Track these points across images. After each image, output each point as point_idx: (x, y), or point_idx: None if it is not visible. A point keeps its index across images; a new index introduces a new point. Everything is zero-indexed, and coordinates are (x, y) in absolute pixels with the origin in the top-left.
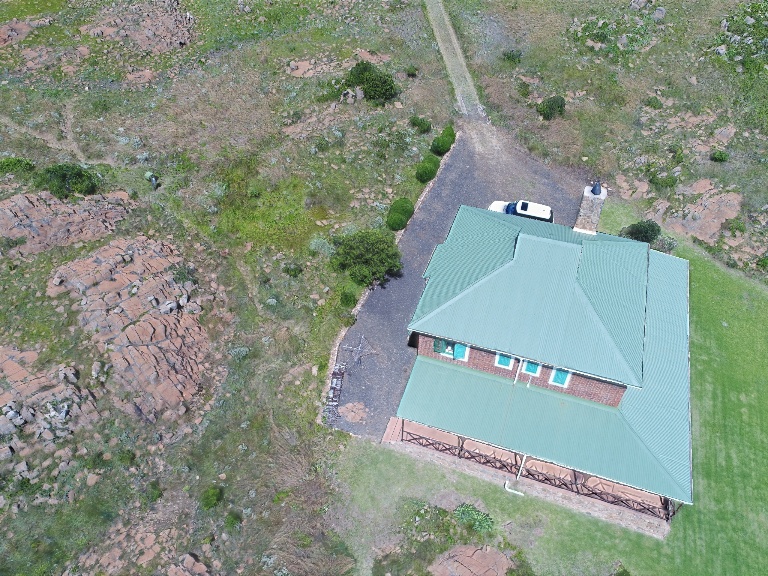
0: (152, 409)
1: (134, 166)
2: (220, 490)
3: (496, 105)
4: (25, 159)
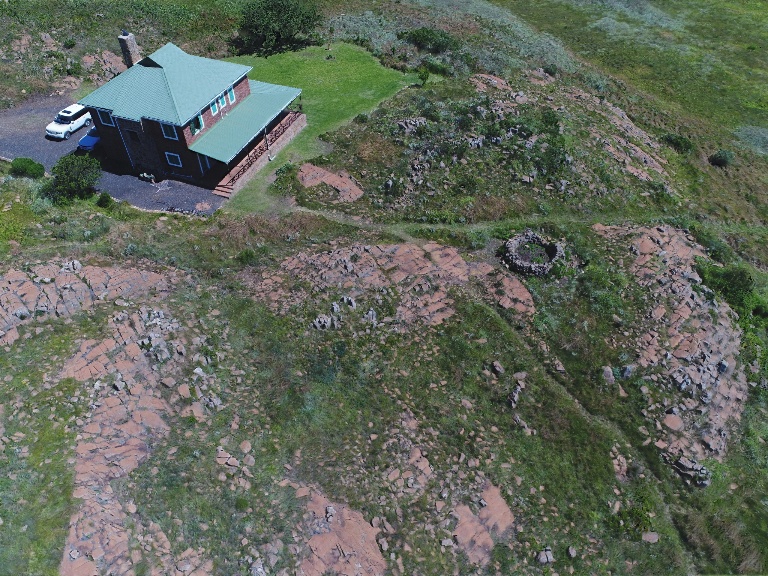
0: (167, 285)
1: None
2: None
3: None
4: None
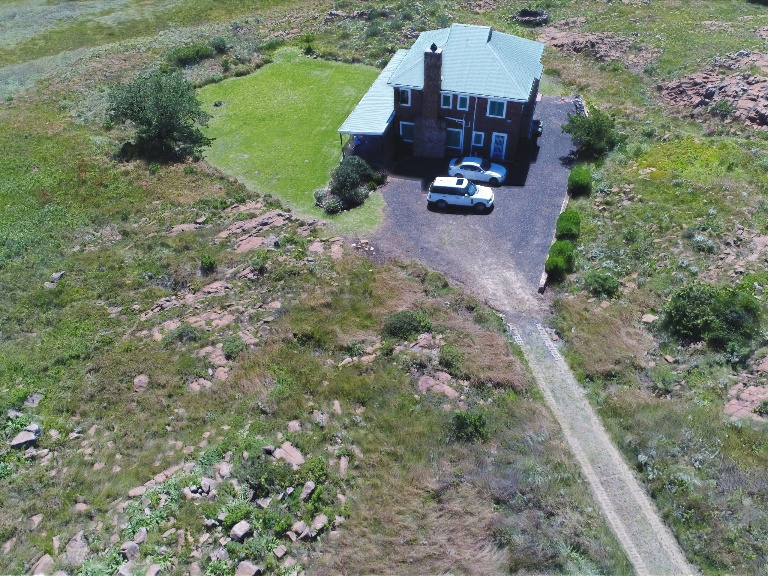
0: None
1: None
2: (615, 69)
3: None
4: None
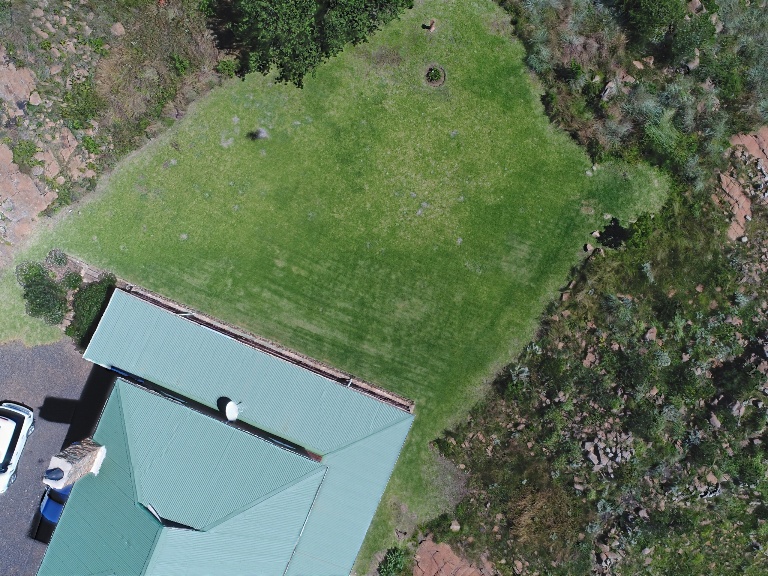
0: None
1: None
2: None
3: None
4: None
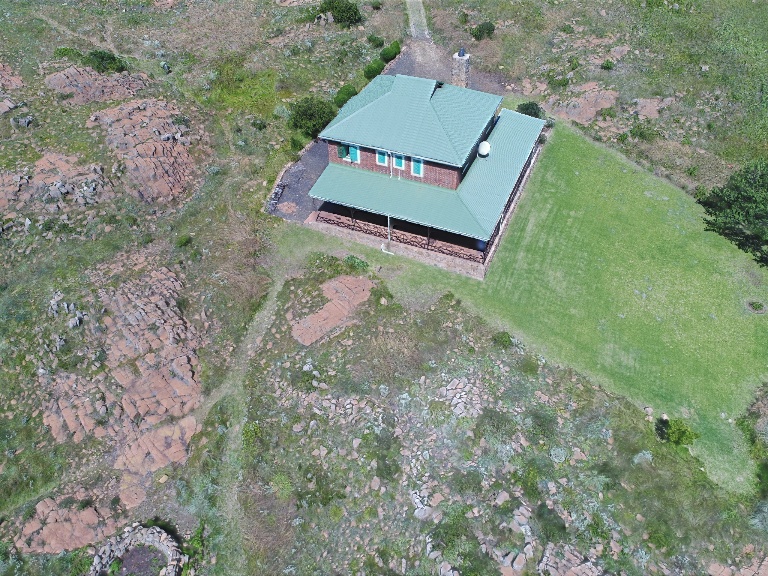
0: (150, 195)
1: (153, 60)
2: (190, 238)
3: (439, 29)
4: (76, 50)
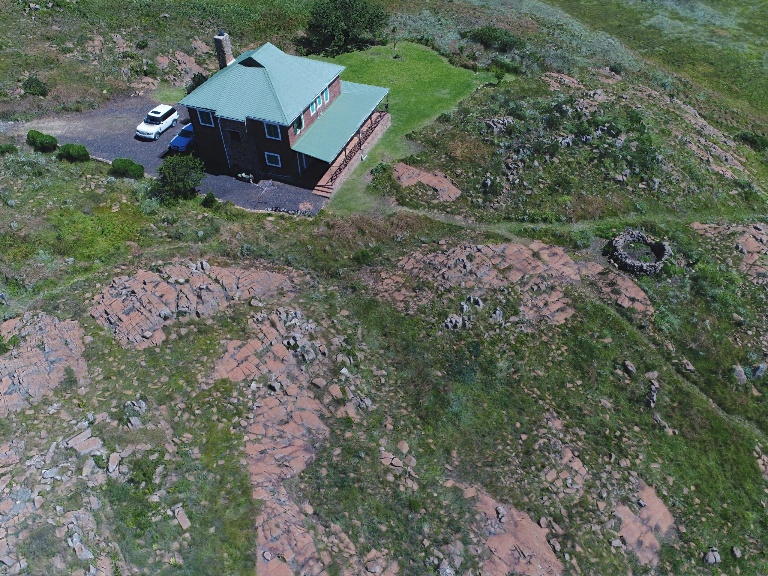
0: (292, 286)
1: None
2: None
3: (6, 112)
4: None
